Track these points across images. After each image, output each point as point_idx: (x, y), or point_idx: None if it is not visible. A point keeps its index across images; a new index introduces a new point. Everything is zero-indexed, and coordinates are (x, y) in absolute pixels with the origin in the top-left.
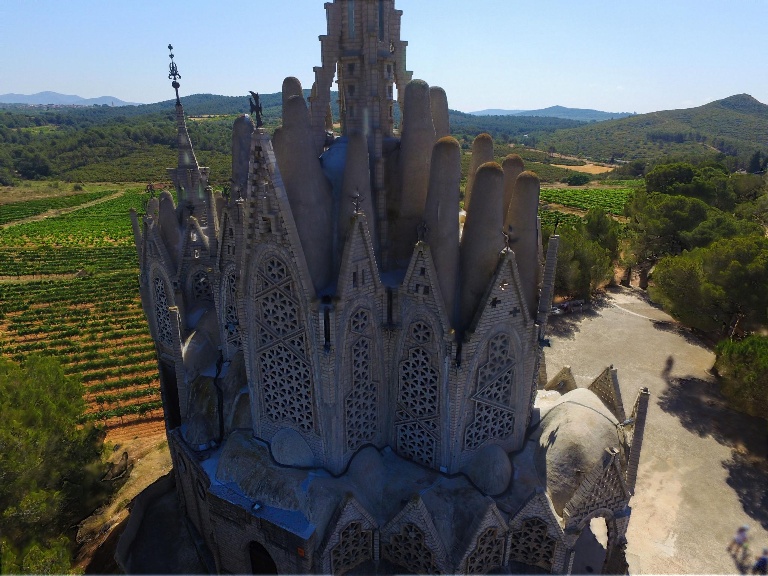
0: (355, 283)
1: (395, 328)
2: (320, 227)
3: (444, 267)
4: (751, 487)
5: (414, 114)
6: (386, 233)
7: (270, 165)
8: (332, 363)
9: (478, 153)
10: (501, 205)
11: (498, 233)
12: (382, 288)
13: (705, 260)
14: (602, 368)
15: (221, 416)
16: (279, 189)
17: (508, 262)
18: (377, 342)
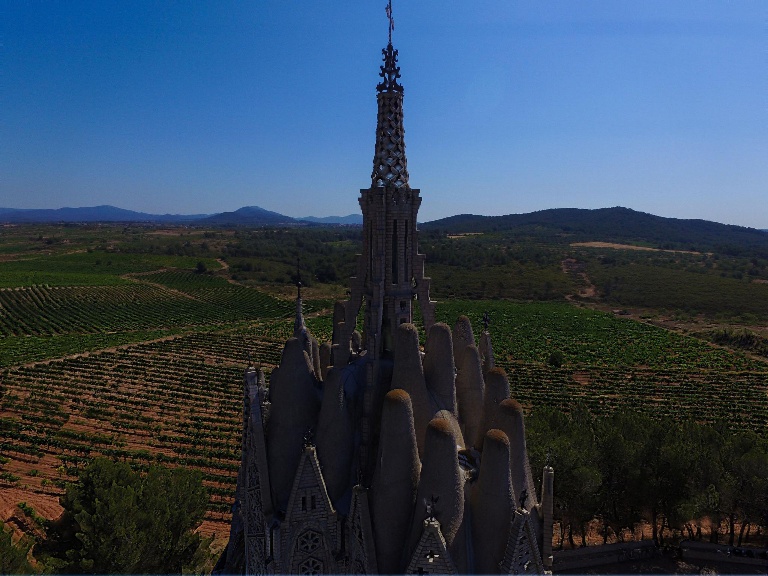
0: (305, 506)
1: (348, 557)
2: (294, 446)
3: (382, 515)
4: None
5: (399, 354)
6: (366, 457)
7: (250, 396)
8: (277, 575)
9: (487, 387)
10: (448, 465)
11: (442, 494)
12: (334, 516)
13: None
14: None
15: (243, 575)
16: (254, 416)
17: (430, 534)
18: (331, 566)
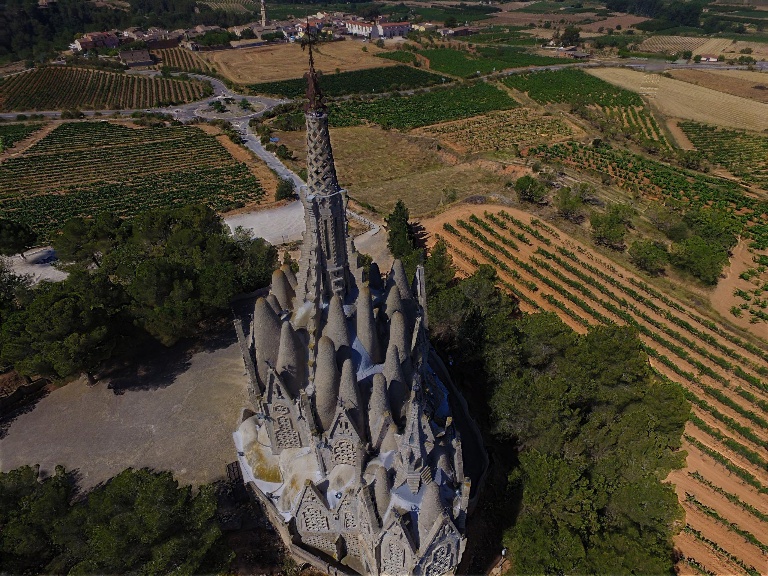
0: None
1: None
2: None
3: None
4: (223, 342)
5: None
6: None
7: None
8: None
9: None
10: None
11: None
12: None
13: (53, 335)
14: (129, 429)
15: None
16: None
17: None
18: None
